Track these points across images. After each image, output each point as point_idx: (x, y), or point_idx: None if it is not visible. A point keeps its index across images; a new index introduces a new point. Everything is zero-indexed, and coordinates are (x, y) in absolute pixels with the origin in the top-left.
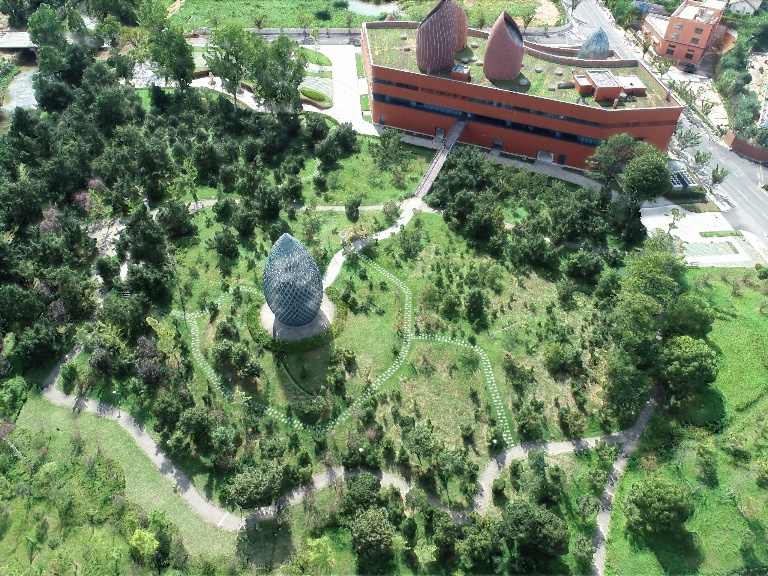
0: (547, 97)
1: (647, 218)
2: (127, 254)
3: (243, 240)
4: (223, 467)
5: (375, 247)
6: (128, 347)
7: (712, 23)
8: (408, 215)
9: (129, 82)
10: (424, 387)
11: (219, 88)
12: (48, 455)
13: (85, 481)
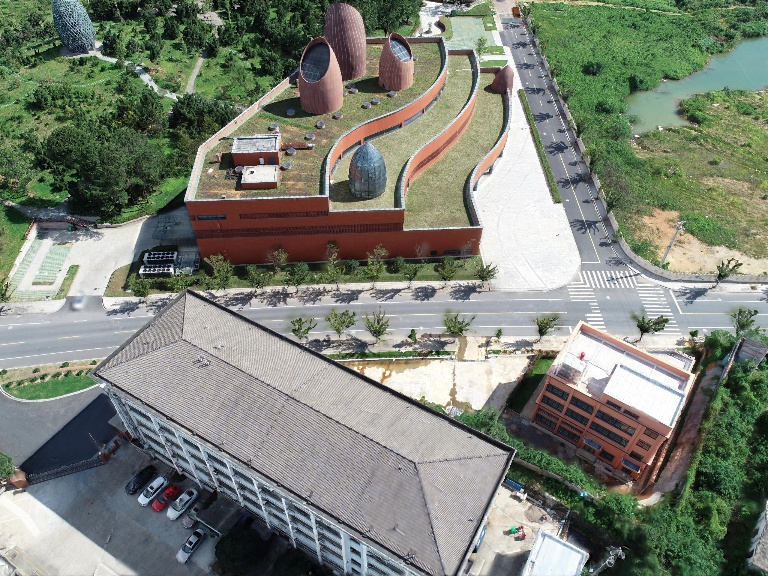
0: (256, 124)
1: (121, 234)
2: (171, 8)
3: (165, 36)
4: (7, 45)
5: (133, 76)
6: (97, 17)
7: (551, 372)
8: (174, 96)
9: (424, 3)
10: (0, 88)
11: (419, 35)
12: (45, 10)
13: (22, 16)
